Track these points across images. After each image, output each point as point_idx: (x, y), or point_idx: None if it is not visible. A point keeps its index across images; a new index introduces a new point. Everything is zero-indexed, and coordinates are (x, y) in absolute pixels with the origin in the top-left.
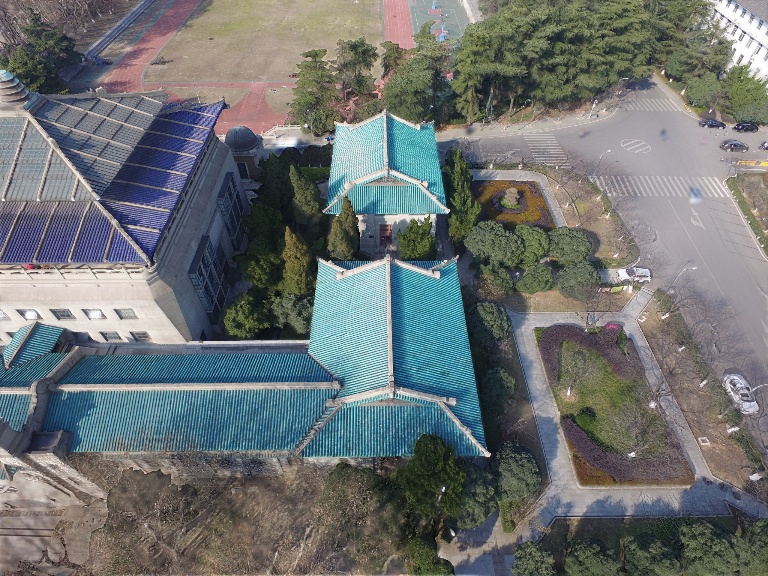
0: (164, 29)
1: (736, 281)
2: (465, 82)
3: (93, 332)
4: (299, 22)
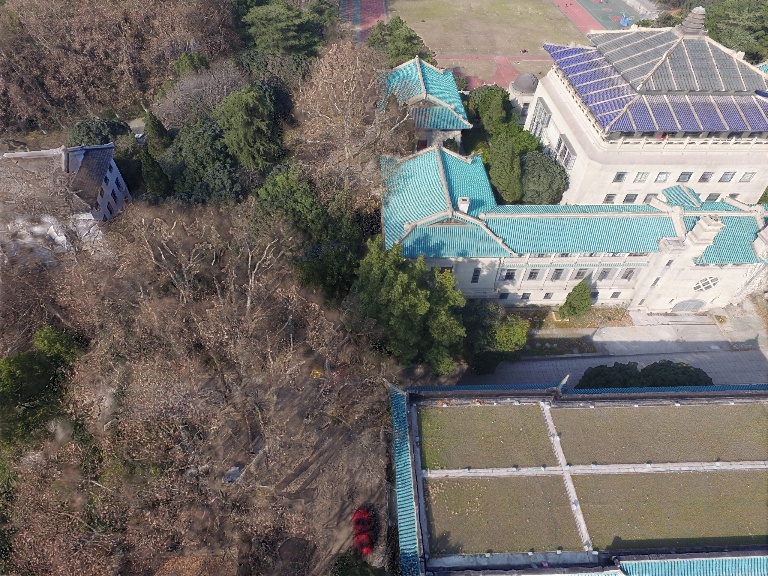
0: (373, 12)
1: None
2: (767, 47)
3: (705, 194)
4: (487, 8)
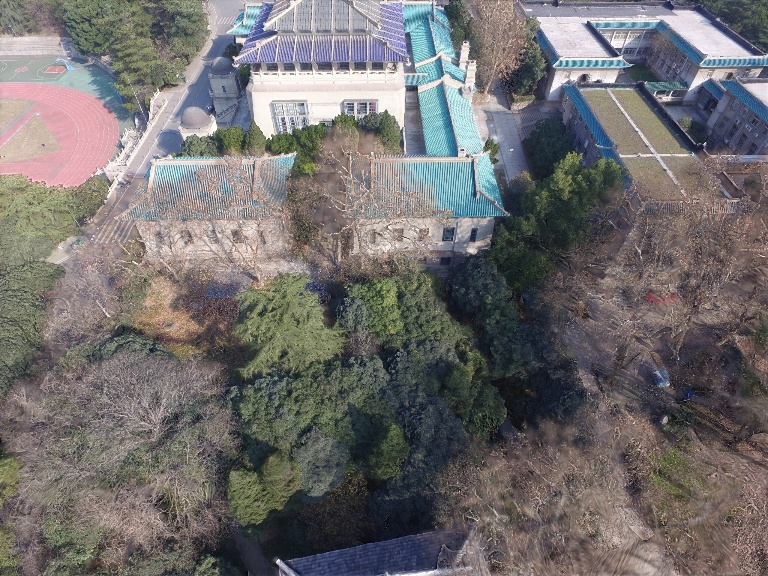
0: None
1: None
2: None
3: None
4: None
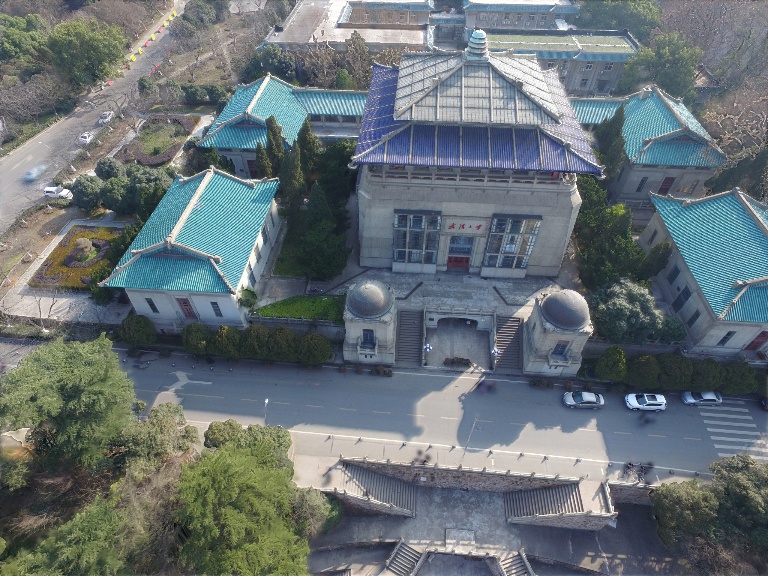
0: None
1: None
2: None
3: None
4: None
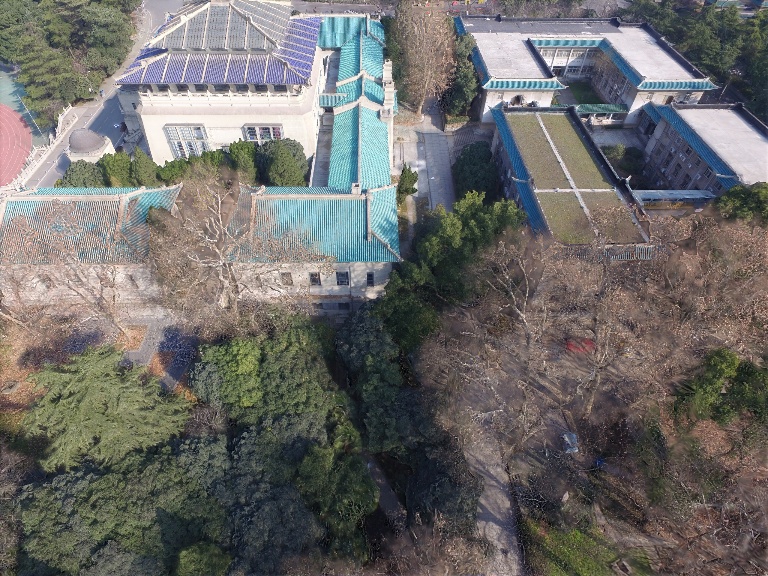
0: None
1: (297, 7)
2: None
3: None
4: None
